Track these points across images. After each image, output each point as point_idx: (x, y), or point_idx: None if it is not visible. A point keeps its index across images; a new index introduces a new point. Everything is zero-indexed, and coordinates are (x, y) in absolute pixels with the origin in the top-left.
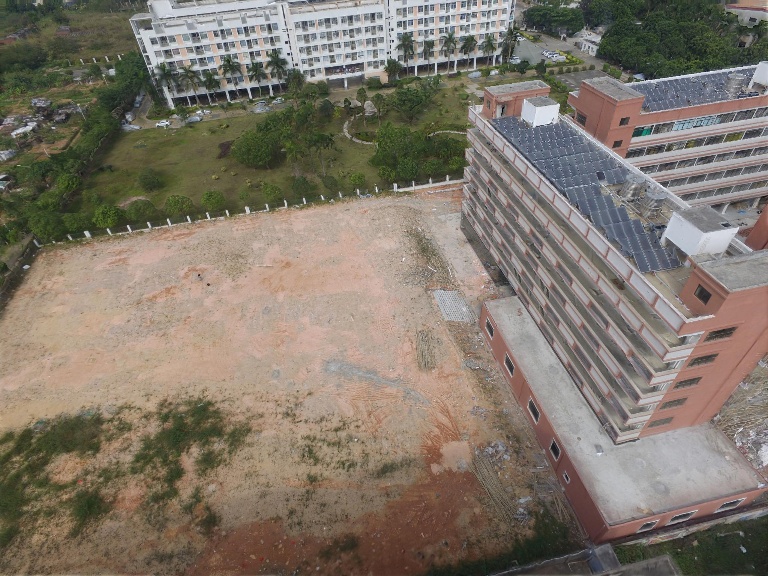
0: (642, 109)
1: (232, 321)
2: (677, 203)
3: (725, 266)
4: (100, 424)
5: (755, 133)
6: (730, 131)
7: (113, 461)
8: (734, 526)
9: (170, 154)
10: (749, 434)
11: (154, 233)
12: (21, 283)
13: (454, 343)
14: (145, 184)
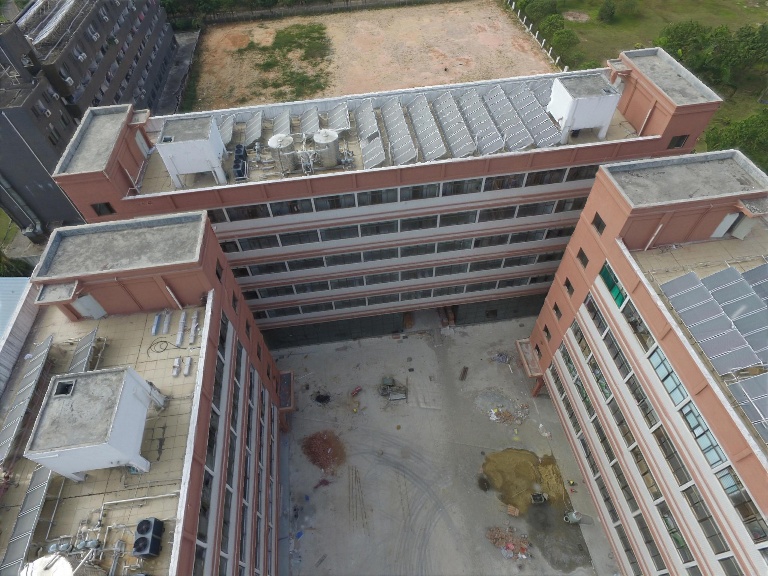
0: None
1: (400, 87)
2: None
3: None
4: (321, 57)
5: None
6: (742, 561)
7: (294, 66)
8: None
9: (688, 14)
10: None
11: (523, 34)
12: (456, 2)
13: None
14: (602, 9)
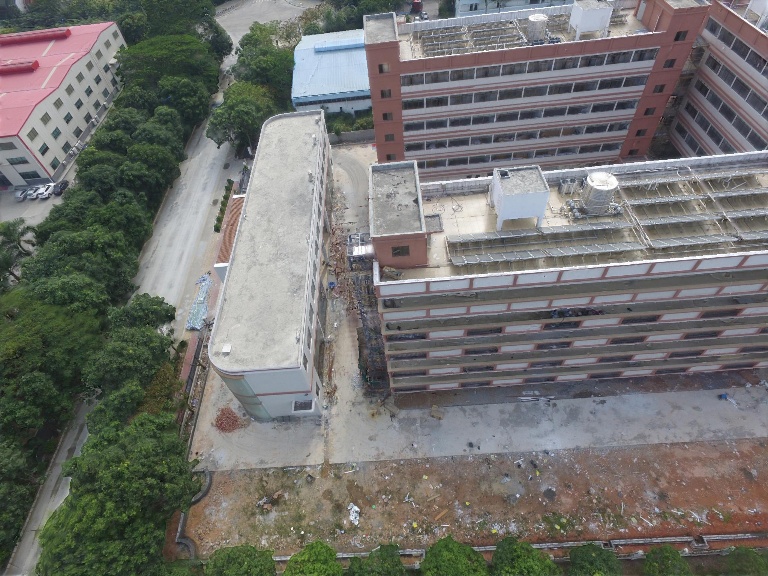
0: None
1: None
2: None
3: None
4: None
5: None
6: None
7: None
8: None
9: None
10: None
11: None
12: None
13: None
14: None
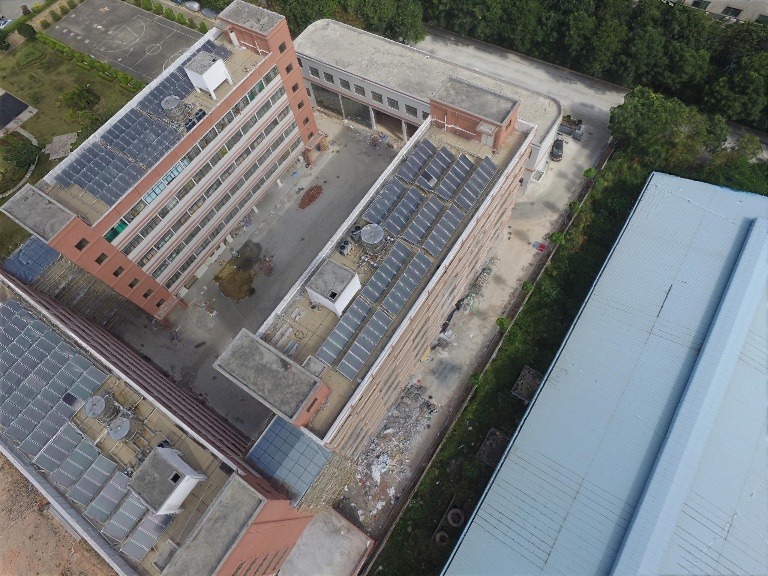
0: (99, 199)
1: None
2: (153, 403)
3: (186, 552)
4: None
5: (236, 138)
6: (209, 157)
7: None
8: (374, 568)
9: None
10: (358, 470)
11: None
12: None
13: (98, 566)
14: None
